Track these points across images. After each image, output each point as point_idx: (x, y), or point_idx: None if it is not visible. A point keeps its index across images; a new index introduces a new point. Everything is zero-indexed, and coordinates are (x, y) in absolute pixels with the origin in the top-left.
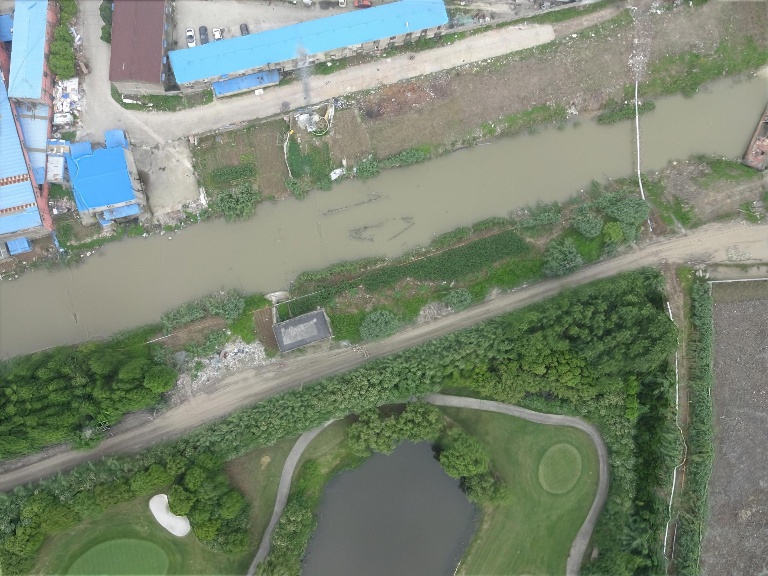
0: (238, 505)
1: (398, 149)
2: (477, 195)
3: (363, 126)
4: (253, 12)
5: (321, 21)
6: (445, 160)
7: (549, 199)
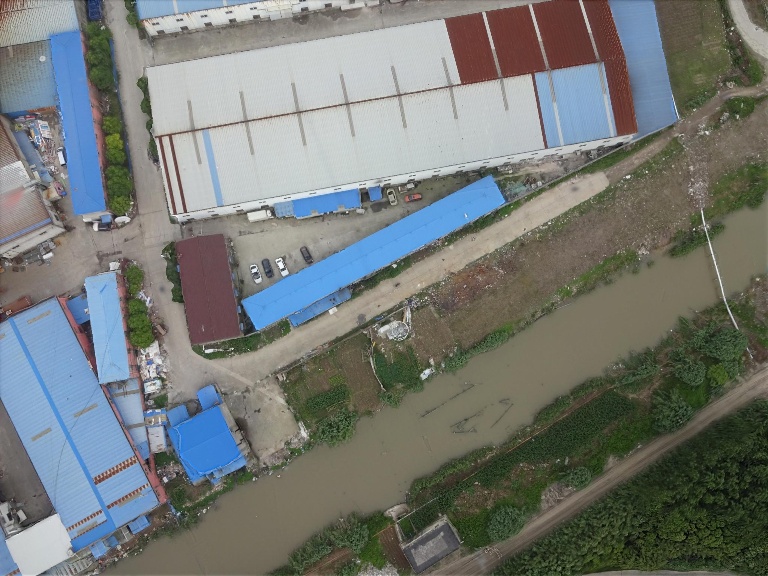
0: None
1: (481, 335)
2: (568, 360)
3: (442, 321)
4: (309, 232)
5: (381, 233)
6: (528, 333)
7: (640, 347)
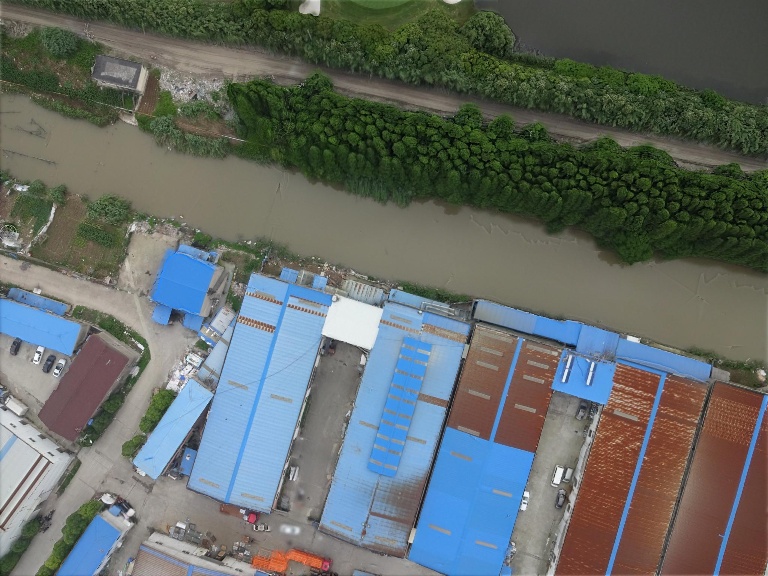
0: None
1: None
2: None
3: None
4: (0, 361)
5: None
6: None
7: None
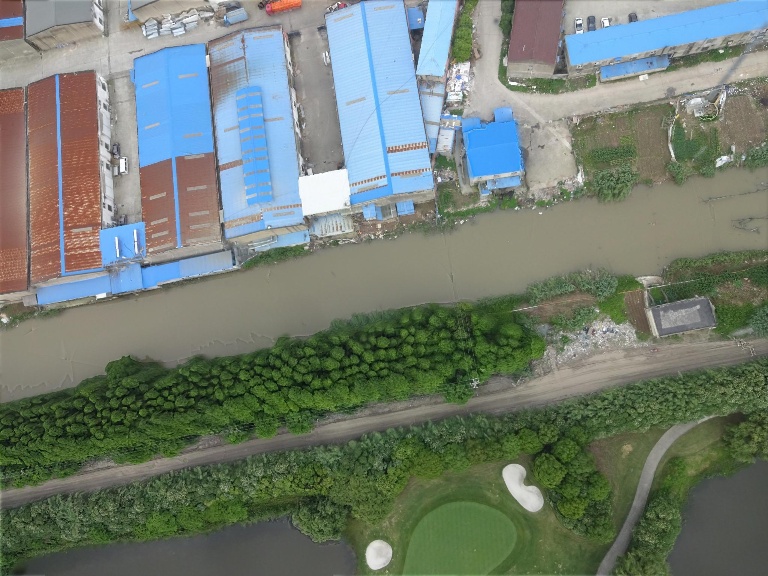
0: (606, 488)
1: None
2: None
3: (757, 113)
4: (642, 2)
5: (725, 6)
6: None
7: None
